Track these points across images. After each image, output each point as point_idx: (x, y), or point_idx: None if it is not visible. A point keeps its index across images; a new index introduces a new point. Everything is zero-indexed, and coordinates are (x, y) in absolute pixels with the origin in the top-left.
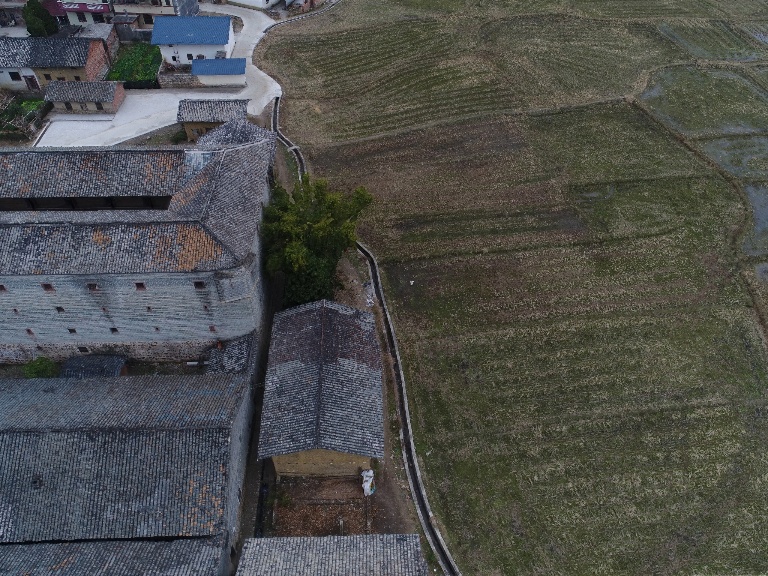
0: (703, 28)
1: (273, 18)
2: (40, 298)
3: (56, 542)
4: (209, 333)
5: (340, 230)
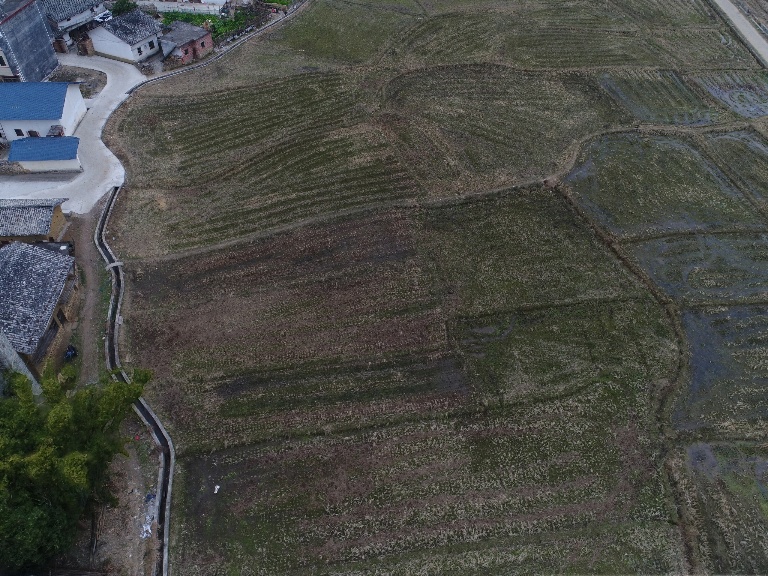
0: (651, 80)
1: (144, 74)
2: None
3: None
4: None
5: (64, 465)
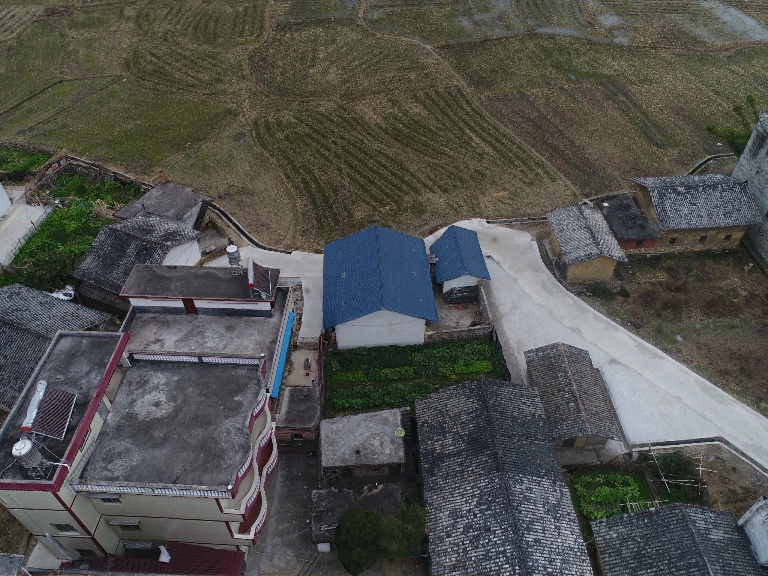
0: (291, 5)
1: None
2: None
3: None
4: None
5: None
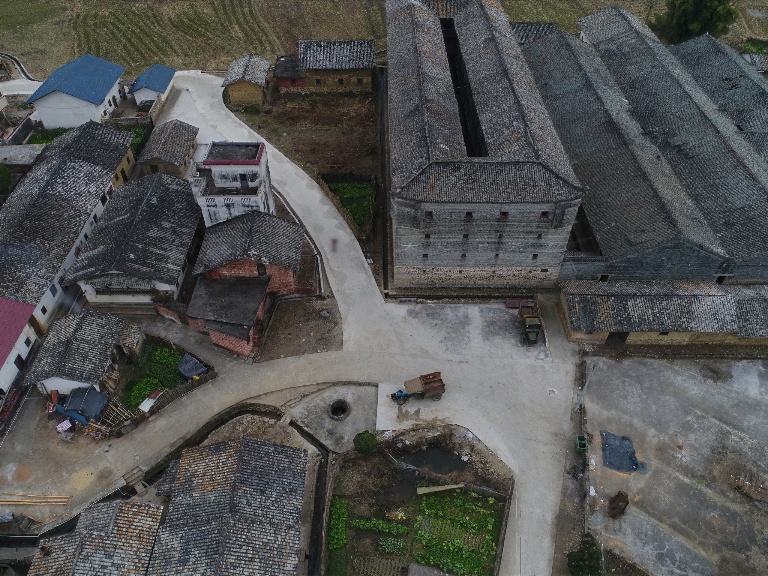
0: None
1: (12, 79)
2: None
3: None
4: None
5: None
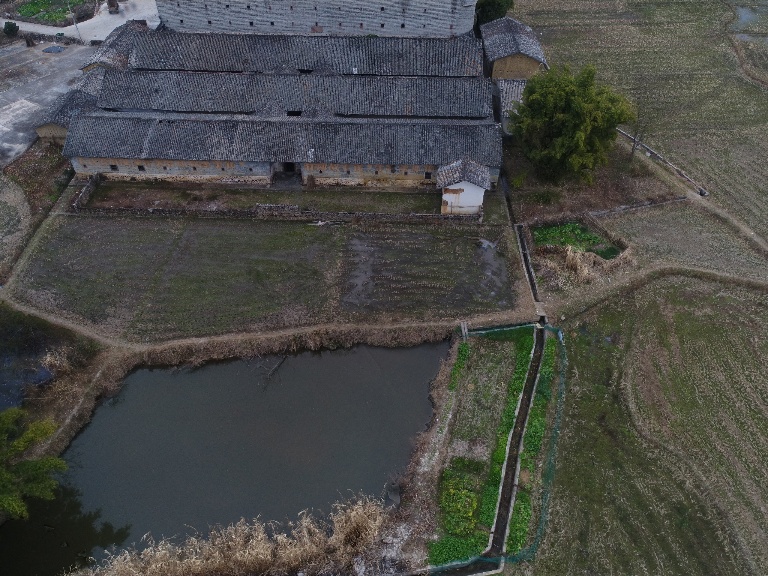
0: None
1: None
2: (376, 0)
3: (411, 76)
4: (449, 31)
5: None
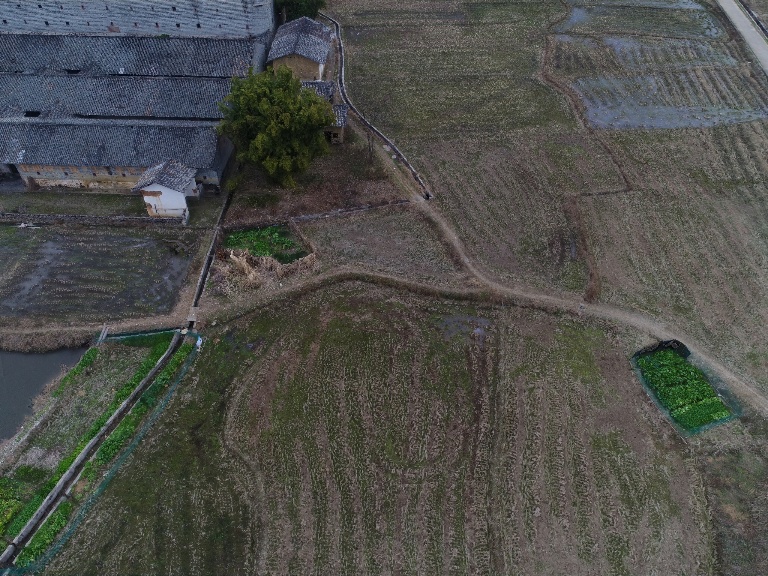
0: None
1: None
2: (166, 0)
3: (177, 76)
4: (246, 31)
5: None
